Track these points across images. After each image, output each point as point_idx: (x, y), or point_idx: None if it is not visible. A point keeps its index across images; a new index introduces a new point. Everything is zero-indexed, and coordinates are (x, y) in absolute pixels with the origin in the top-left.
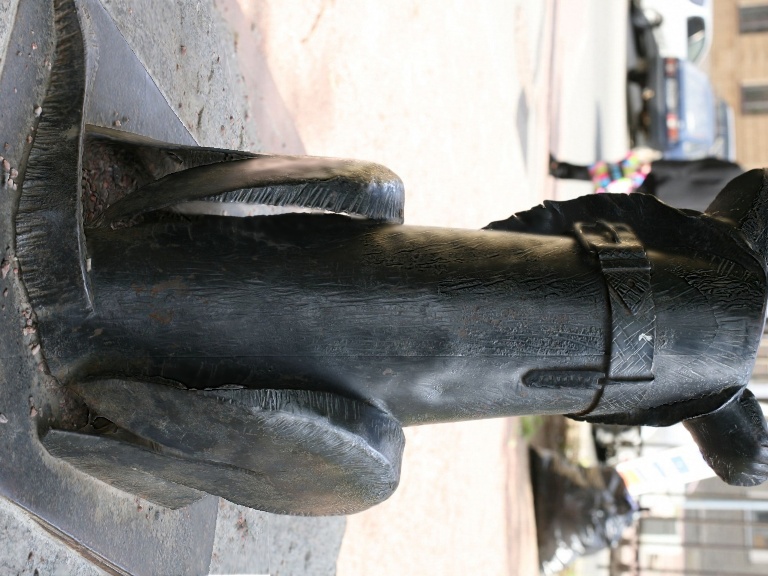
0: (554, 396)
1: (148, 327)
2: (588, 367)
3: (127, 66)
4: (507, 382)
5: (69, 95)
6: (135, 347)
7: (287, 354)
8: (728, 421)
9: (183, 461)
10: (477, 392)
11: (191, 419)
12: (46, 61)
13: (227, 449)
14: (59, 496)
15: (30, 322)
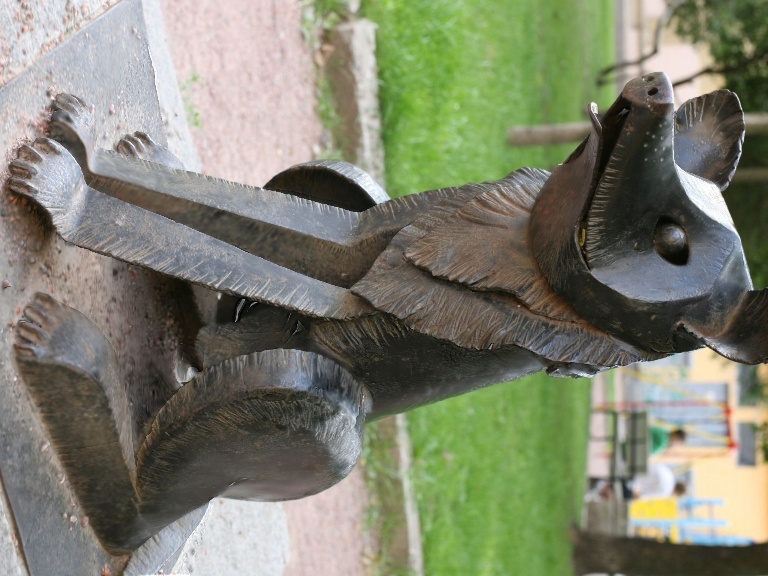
0: None
1: None
2: None
3: (44, 567)
4: None
5: None
6: None
7: None
8: None
9: None
10: None
11: None
12: None
13: None
14: None
15: None
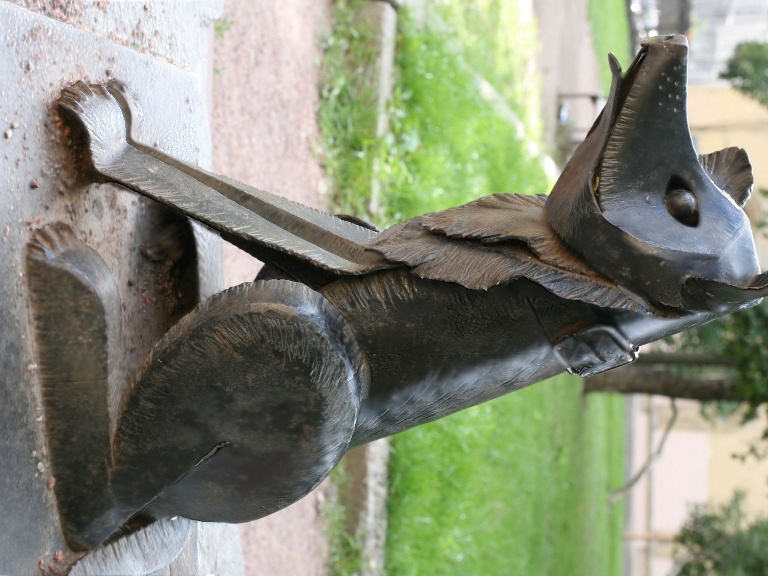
0: None
1: None
2: None
3: (2, 484)
4: None
5: None
6: None
7: None
8: None
9: None
10: None
11: None
12: None
13: None
14: None
15: None
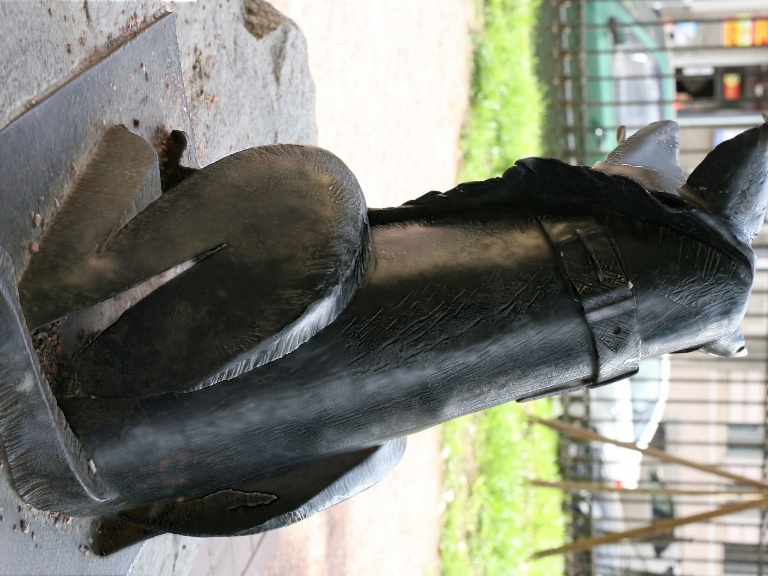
0: None
1: (166, 489)
2: (576, 381)
3: (19, 148)
4: None
5: (5, 337)
6: (159, 500)
7: (297, 461)
8: None
9: None
10: None
11: None
12: None
13: None
14: (123, 551)
15: (57, 513)
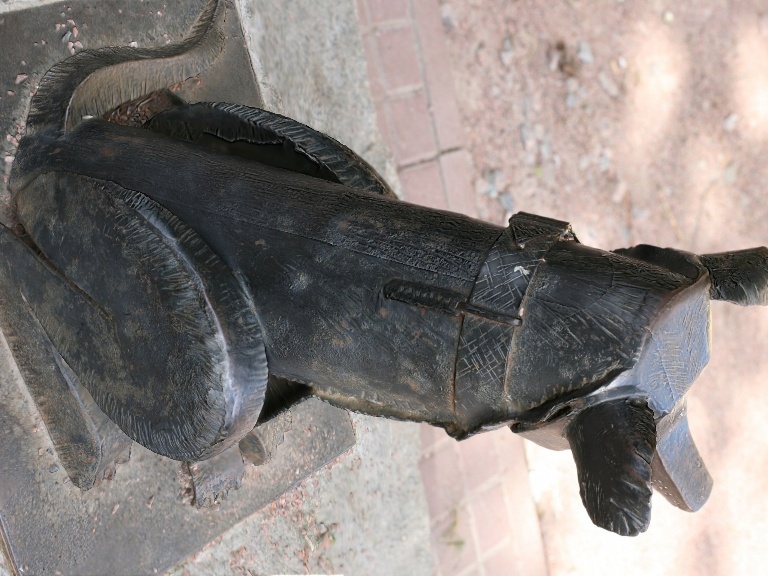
0: (415, 328)
1: (94, 156)
2: (454, 291)
3: None
4: (369, 290)
5: None
6: (75, 168)
7: (184, 203)
8: (605, 419)
9: (55, 278)
10: (337, 295)
11: (72, 213)
12: (166, 34)
13: (89, 263)
14: None
15: (19, 138)
